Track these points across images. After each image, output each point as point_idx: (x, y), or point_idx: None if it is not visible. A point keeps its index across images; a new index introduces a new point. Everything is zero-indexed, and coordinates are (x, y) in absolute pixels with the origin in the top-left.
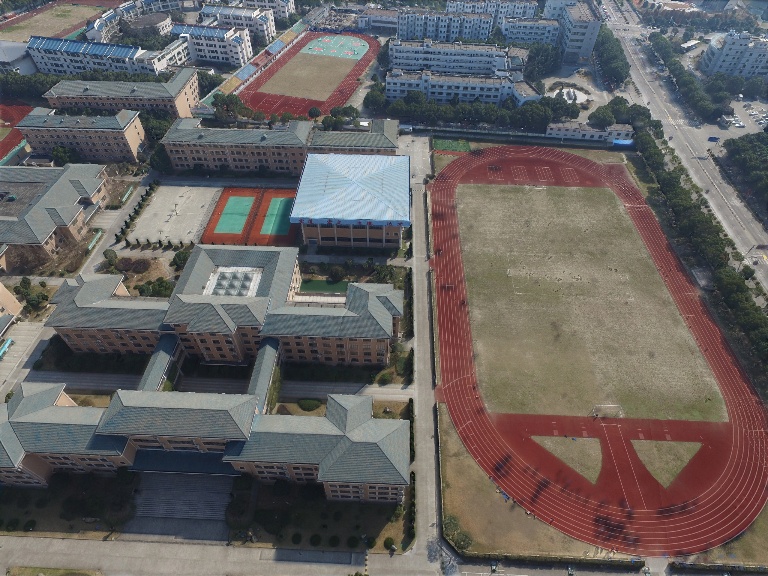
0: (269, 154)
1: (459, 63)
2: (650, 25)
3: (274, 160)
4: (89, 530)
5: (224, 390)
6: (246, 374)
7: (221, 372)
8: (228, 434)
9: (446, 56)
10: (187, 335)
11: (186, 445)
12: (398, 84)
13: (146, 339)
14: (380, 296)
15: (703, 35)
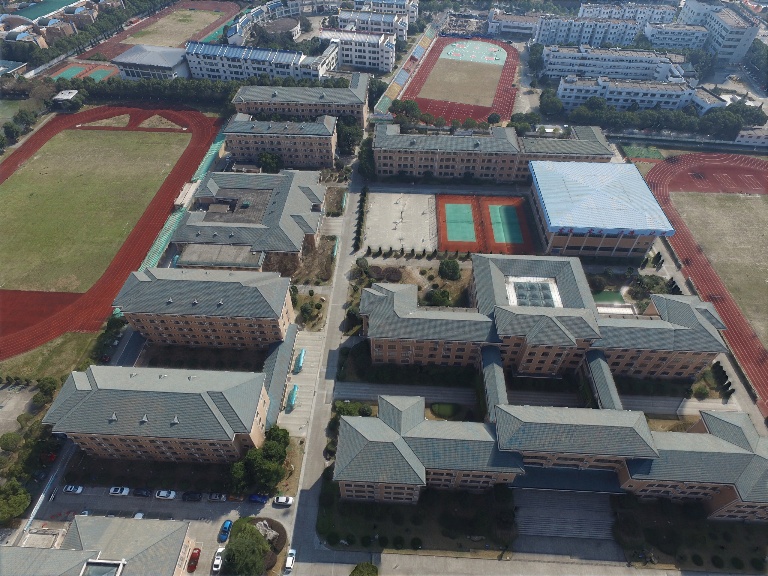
0: (479, 161)
1: (616, 69)
2: None
3: (481, 167)
4: (479, 549)
5: (542, 403)
6: (562, 387)
7: (536, 385)
8: (639, 452)
9: (604, 62)
10: (509, 347)
11: (571, 462)
12: (575, 90)
13: (460, 350)
14: (700, 308)
15: None
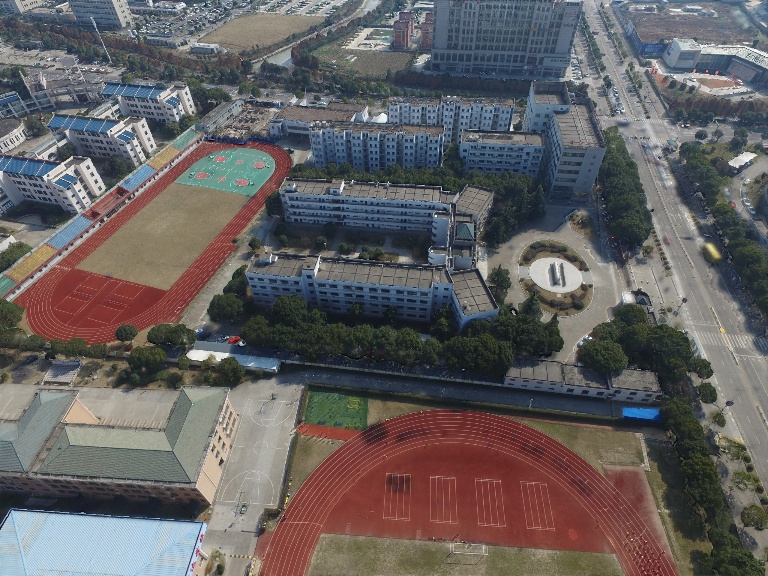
0: None
1: (385, 215)
2: (680, 120)
3: None
4: None
5: None
6: None
7: None
8: None
9: (364, 206)
10: None
11: None
12: (266, 280)
13: None
14: None
15: (760, 138)
